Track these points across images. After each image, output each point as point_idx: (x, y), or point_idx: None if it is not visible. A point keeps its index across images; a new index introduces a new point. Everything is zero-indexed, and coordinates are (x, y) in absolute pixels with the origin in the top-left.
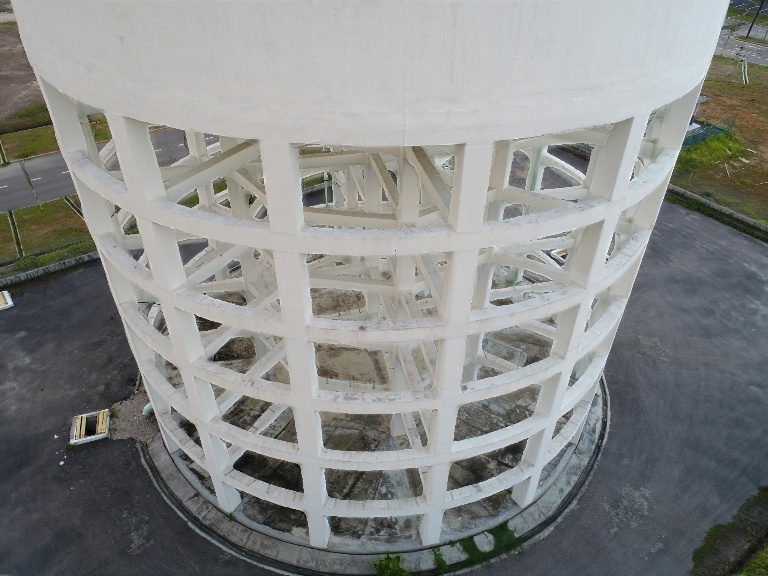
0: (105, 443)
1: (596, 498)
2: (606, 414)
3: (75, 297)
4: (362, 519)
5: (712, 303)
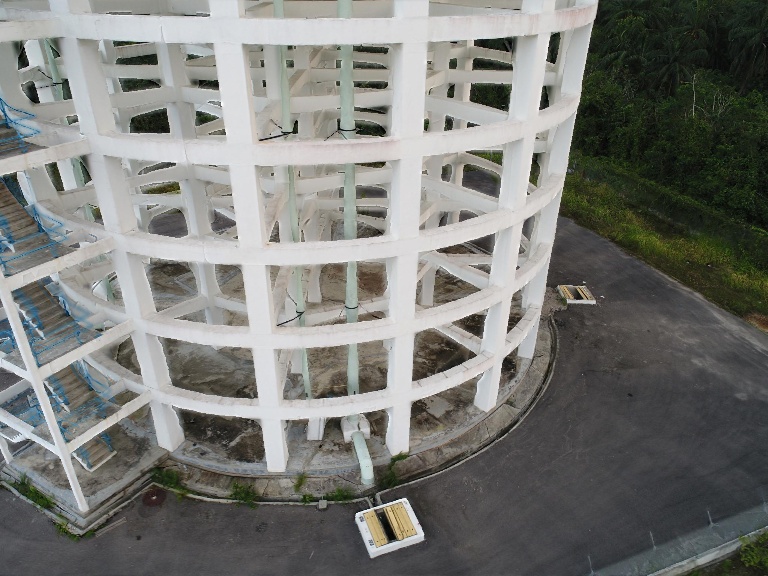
0: None
1: (223, 225)
2: None
3: (720, 443)
4: (370, 227)
5: None
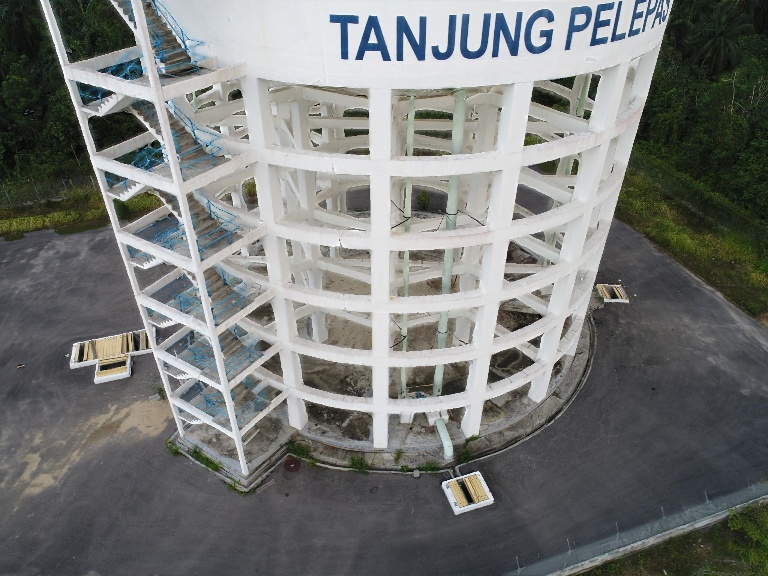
0: (596, 284)
1: None
2: (253, 244)
3: (723, 432)
4: None
5: (56, 297)
